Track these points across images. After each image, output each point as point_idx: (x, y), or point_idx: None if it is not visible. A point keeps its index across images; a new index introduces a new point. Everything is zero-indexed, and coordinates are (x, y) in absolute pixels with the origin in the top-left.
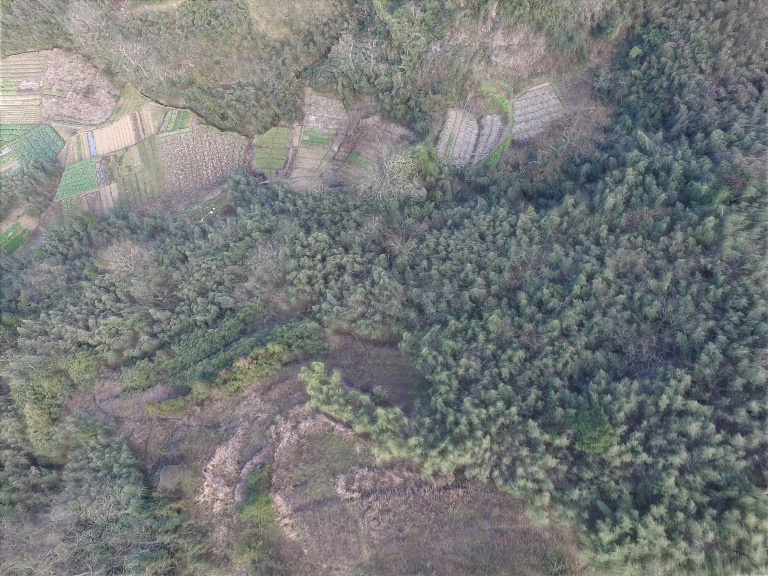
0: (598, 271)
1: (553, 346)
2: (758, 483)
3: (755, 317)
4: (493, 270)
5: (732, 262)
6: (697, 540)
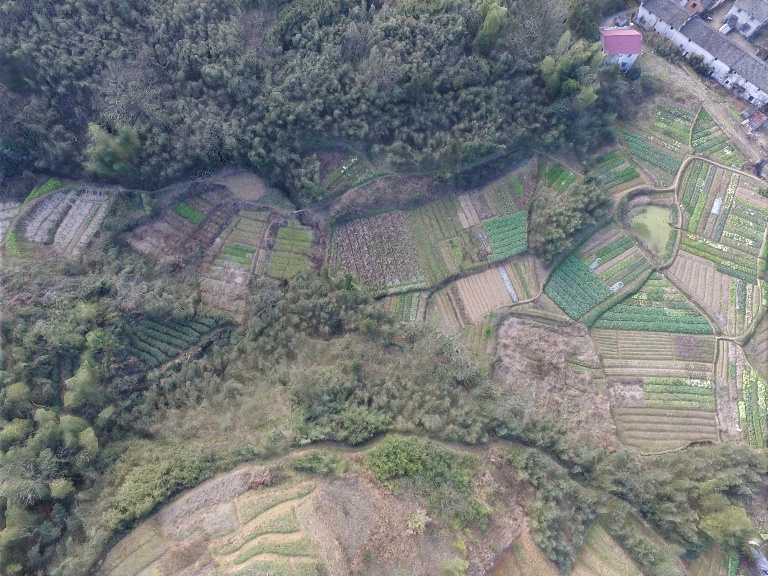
0: None
1: None
2: None
3: None
4: None
5: None
6: None
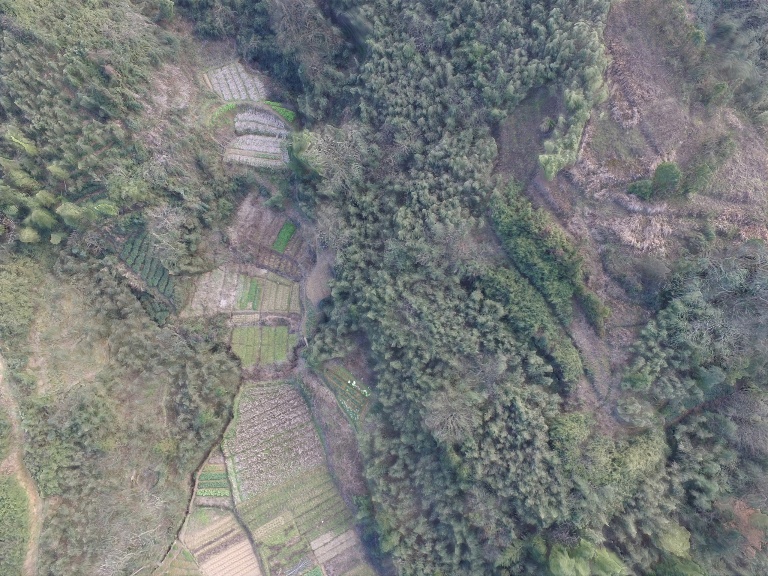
0: None
1: (494, 5)
2: None
3: None
4: (424, 67)
5: None
6: None
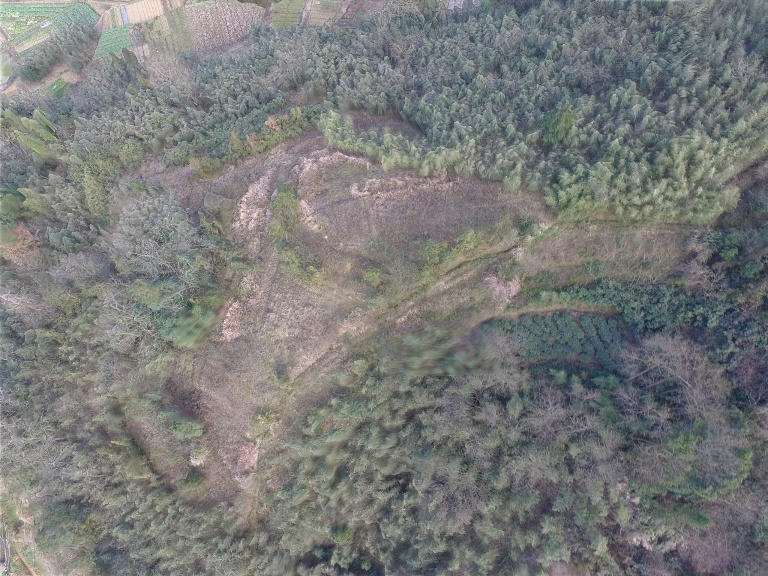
0: (567, 41)
1: (528, 90)
2: (683, 134)
3: (690, 44)
4: None
5: (675, 16)
6: (634, 171)
